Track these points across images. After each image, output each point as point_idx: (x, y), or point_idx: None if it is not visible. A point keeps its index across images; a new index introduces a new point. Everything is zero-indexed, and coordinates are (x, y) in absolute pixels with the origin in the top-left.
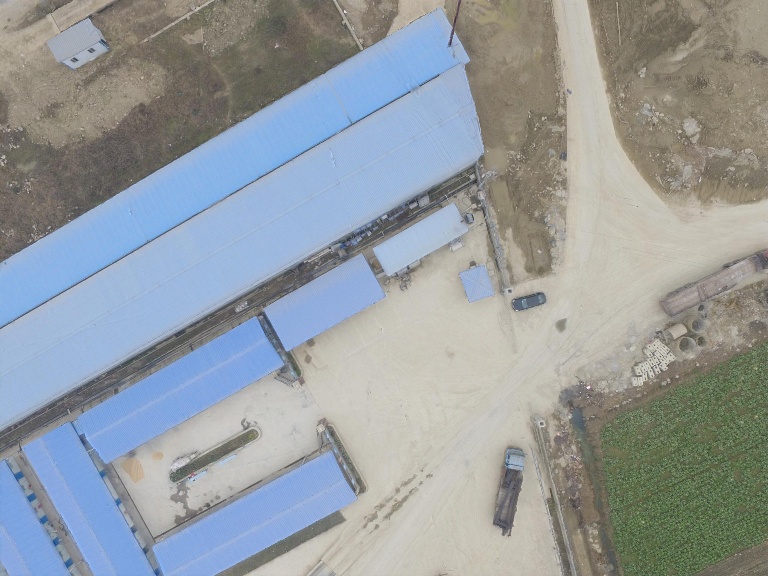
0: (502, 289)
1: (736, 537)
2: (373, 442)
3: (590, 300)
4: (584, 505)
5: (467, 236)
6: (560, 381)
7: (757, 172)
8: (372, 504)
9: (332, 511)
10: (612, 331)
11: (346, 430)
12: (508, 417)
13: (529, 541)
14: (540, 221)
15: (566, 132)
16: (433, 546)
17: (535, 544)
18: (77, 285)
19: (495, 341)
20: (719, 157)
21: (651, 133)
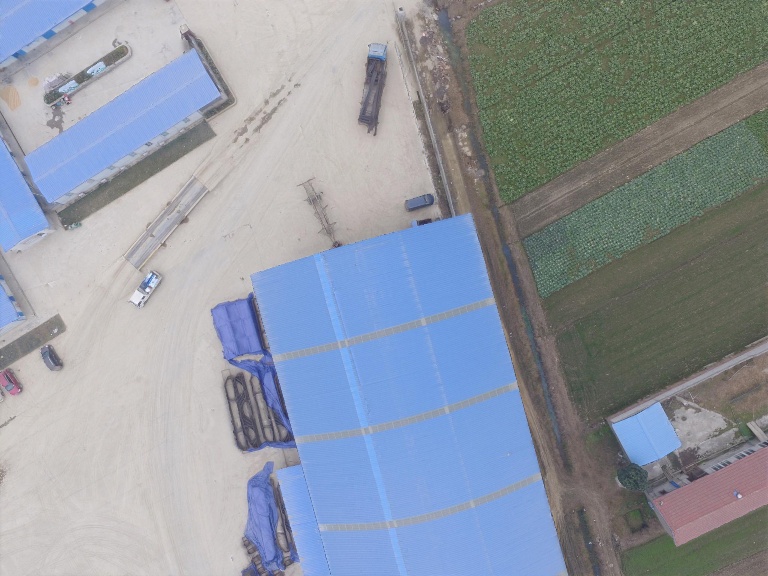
0: None
1: (606, 129)
2: (241, 54)
3: None
4: (452, 108)
5: None
6: None
7: None
8: (242, 118)
9: (196, 108)
10: None
11: (214, 44)
12: (373, 20)
13: (398, 146)
14: None
15: None
16: (303, 157)
17: (404, 149)
18: None
19: None
20: None
21: None
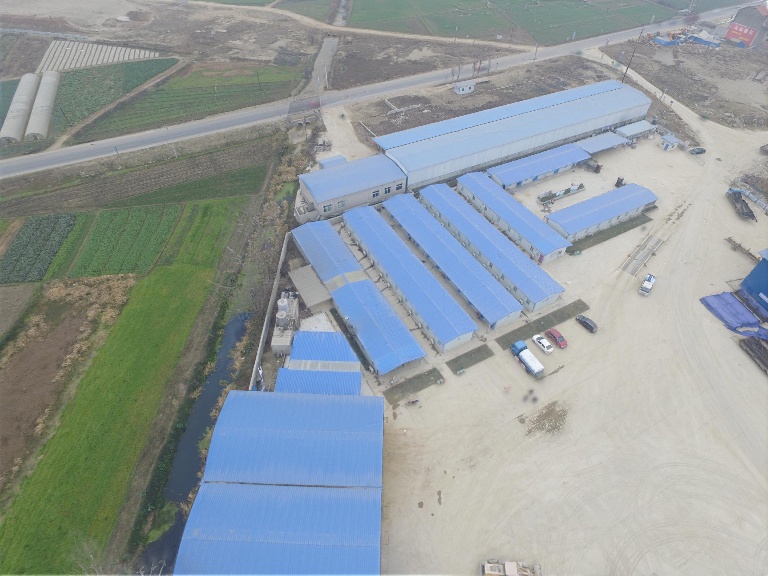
0: (682, 145)
1: None
2: None
3: (726, 153)
4: None
5: (653, 136)
6: (734, 175)
7: (767, 120)
8: (665, 214)
9: (647, 202)
10: (745, 161)
11: None
12: None
13: None
14: (684, 133)
15: (677, 114)
16: (714, 231)
17: None
18: (487, 123)
19: (690, 163)
20: (747, 116)
21: (713, 115)
